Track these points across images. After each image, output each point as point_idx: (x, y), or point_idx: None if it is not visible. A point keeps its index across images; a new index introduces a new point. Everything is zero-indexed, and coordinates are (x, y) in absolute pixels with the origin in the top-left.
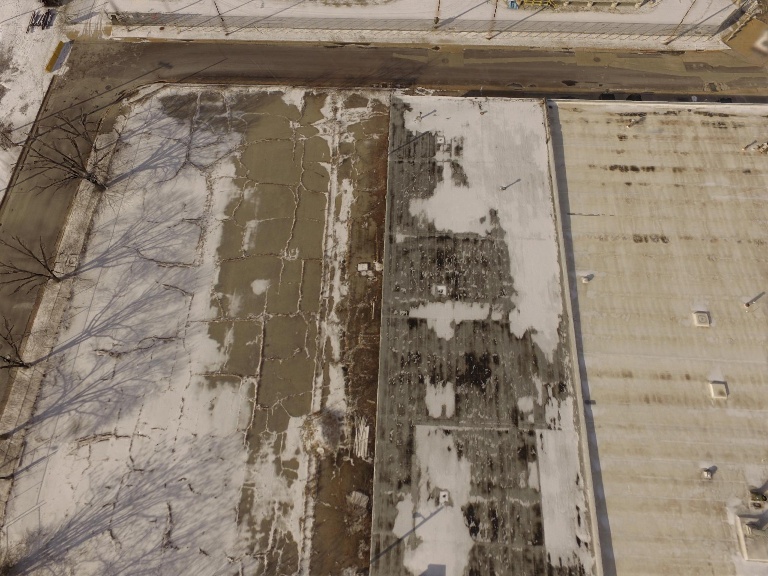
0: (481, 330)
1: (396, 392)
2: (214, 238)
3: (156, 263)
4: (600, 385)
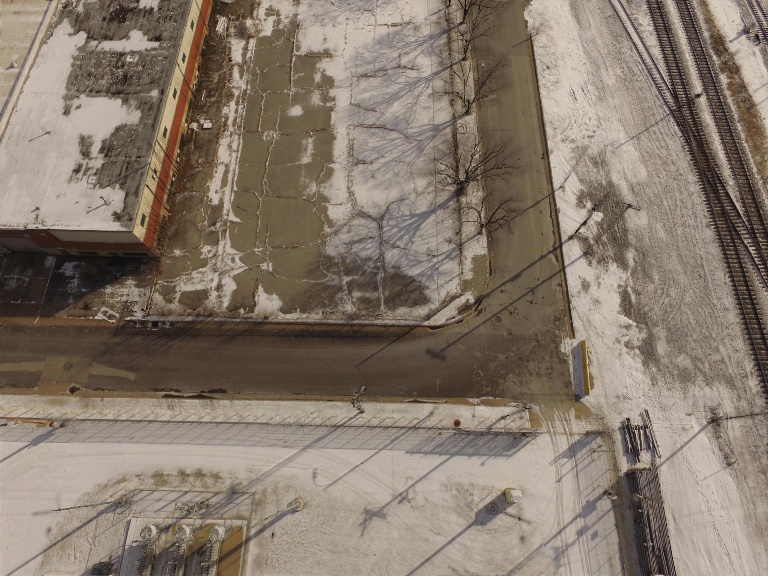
0: (109, 35)
1: (178, 3)
2: (340, 147)
3: (387, 127)
4: (39, 8)
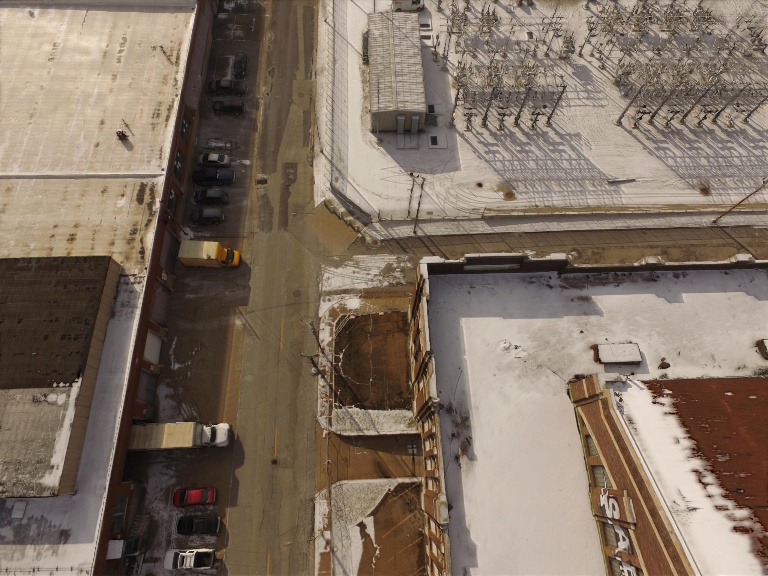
0: None
1: None
2: None
3: None
4: None
